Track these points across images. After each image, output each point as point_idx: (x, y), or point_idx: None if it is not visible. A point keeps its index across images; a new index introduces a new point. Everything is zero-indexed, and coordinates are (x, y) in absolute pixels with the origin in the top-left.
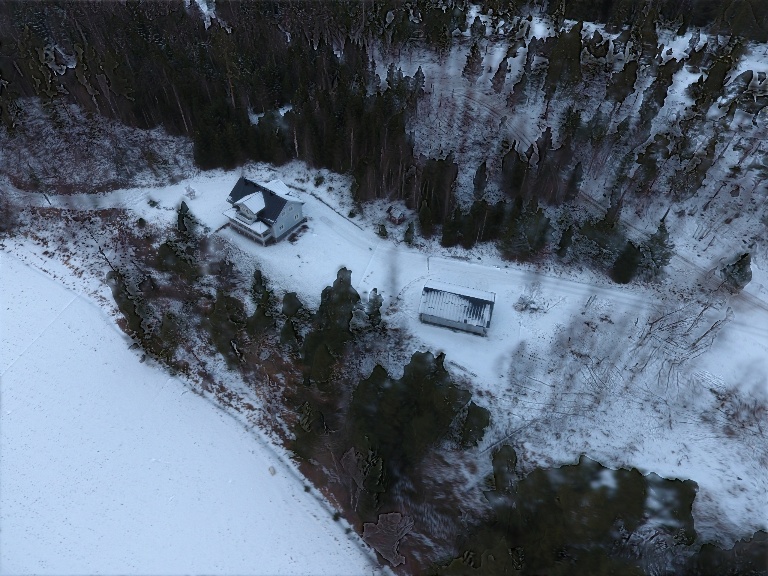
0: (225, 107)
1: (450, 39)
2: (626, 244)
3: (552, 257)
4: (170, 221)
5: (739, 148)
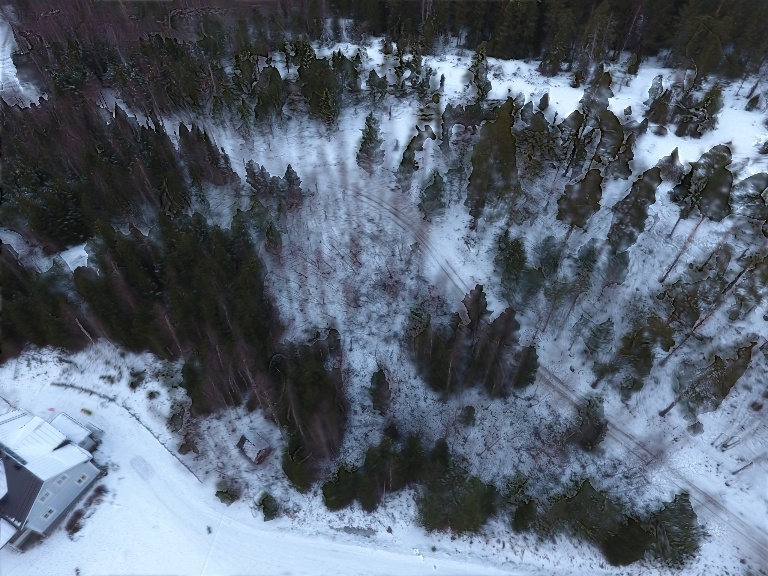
0: None
1: (335, 110)
2: (626, 526)
3: (505, 515)
4: None
5: None
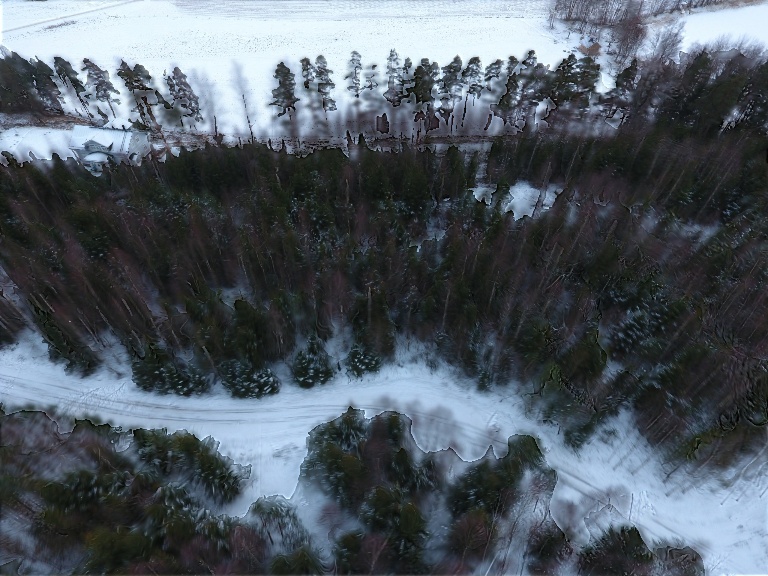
0: None
1: None
2: None
3: None
4: None
5: None
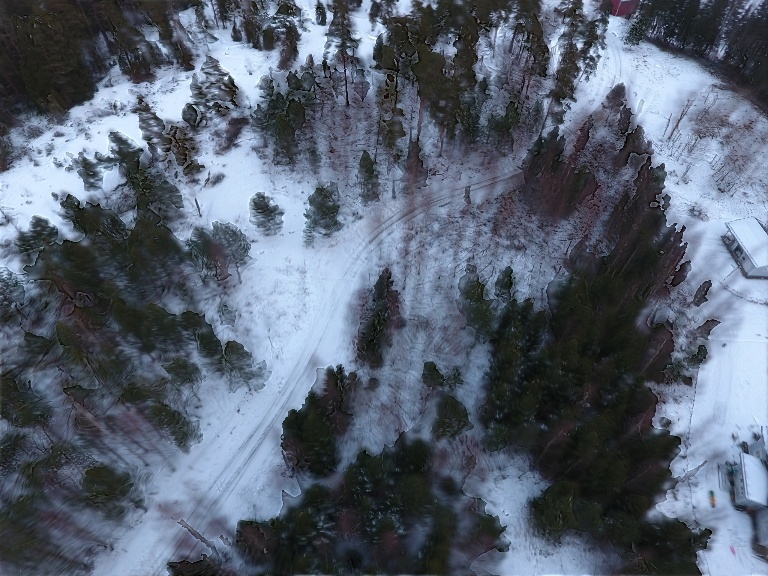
0: None
1: (240, 231)
2: None
3: None
4: None
5: (526, 48)
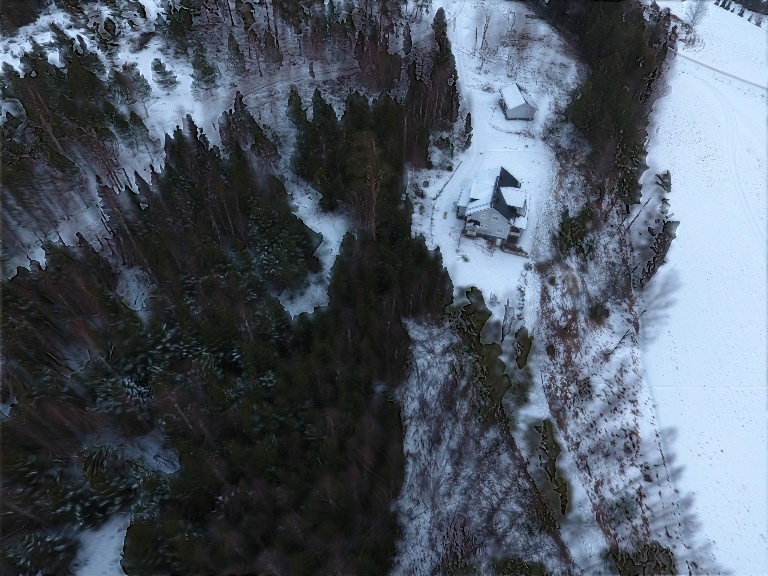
0: None
1: None
2: None
3: None
4: (536, 312)
5: None
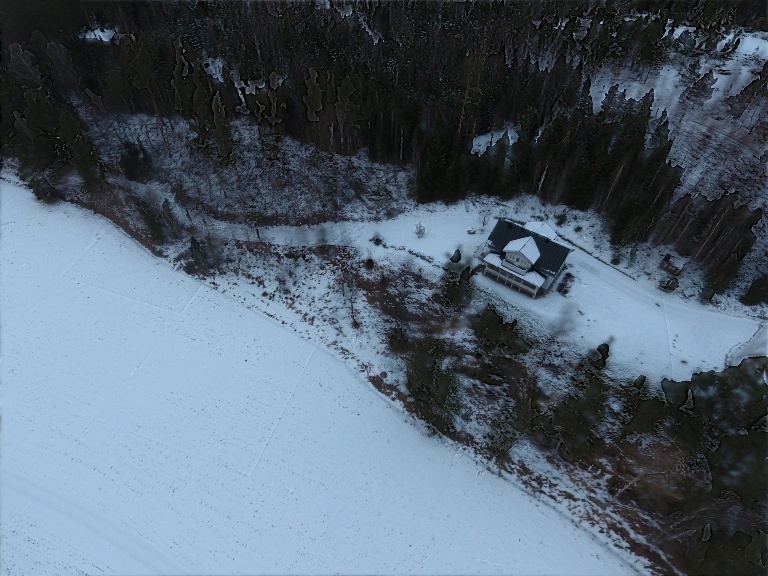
0: (450, 135)
1: (666, 56)
2: None
3: None
4: (405, 263)
5: None
